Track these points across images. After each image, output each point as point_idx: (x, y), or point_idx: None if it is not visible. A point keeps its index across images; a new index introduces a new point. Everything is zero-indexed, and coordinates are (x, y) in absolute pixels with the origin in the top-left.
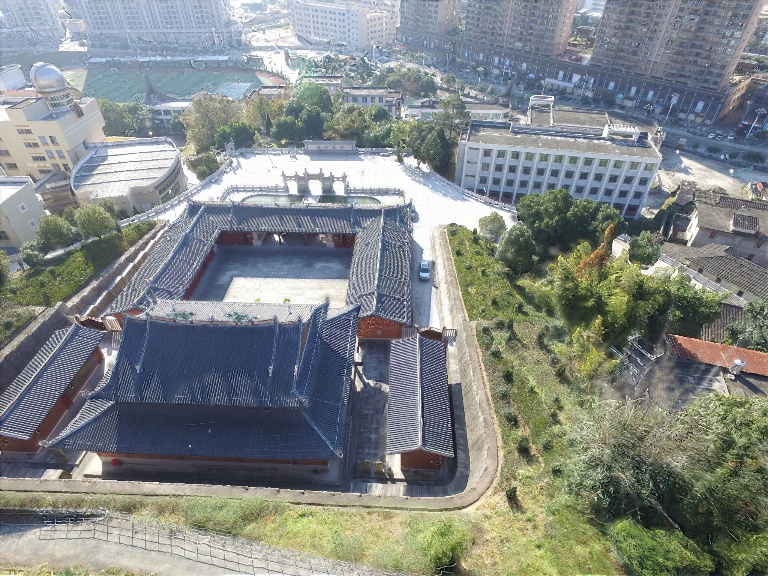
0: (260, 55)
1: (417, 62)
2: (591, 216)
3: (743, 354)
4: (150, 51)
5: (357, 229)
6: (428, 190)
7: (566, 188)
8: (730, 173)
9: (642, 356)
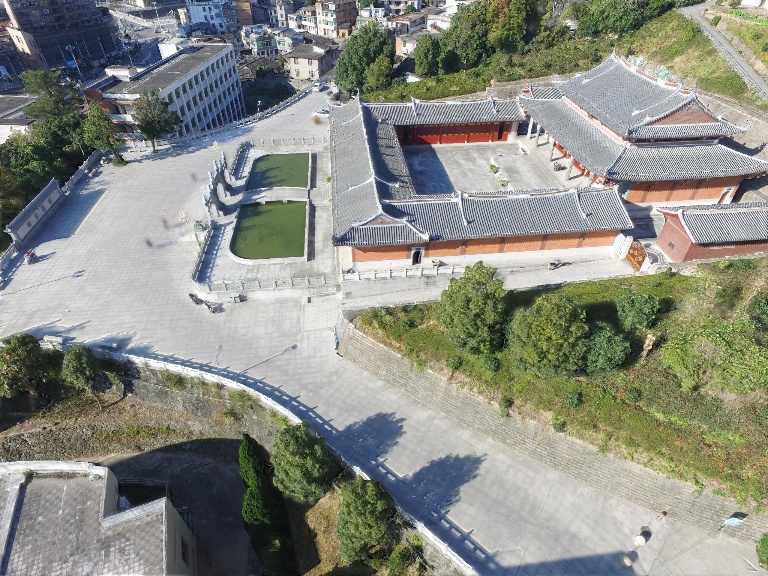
0: None
1: None
2: None
3: None
4: None
5: None
6: (224, 143)
7: (215, 103)
8: None
9: None
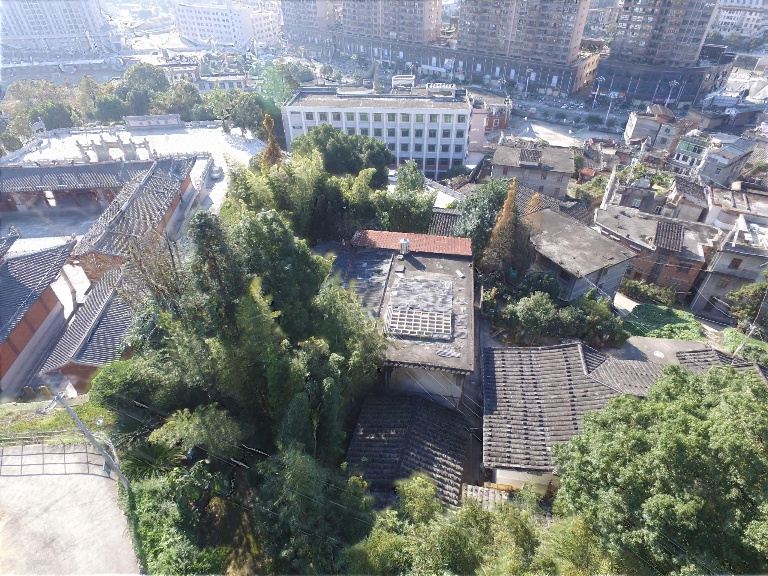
0: (137, 57)
1: (296, 55)
2: (360, 150)
3: (424, 239)
4: (15, 57)
5: (124, 182)
6: (244, 154)
7: (392, 147)
8: (569, 133)
9: (325, 250)
